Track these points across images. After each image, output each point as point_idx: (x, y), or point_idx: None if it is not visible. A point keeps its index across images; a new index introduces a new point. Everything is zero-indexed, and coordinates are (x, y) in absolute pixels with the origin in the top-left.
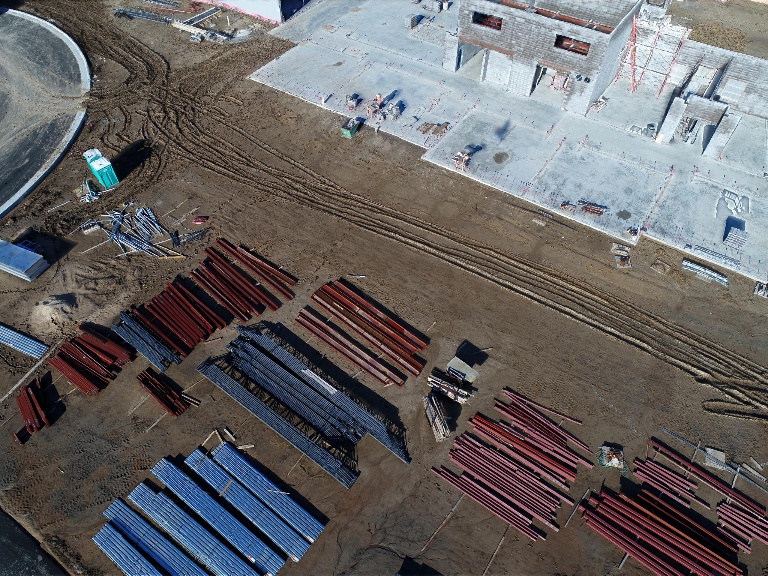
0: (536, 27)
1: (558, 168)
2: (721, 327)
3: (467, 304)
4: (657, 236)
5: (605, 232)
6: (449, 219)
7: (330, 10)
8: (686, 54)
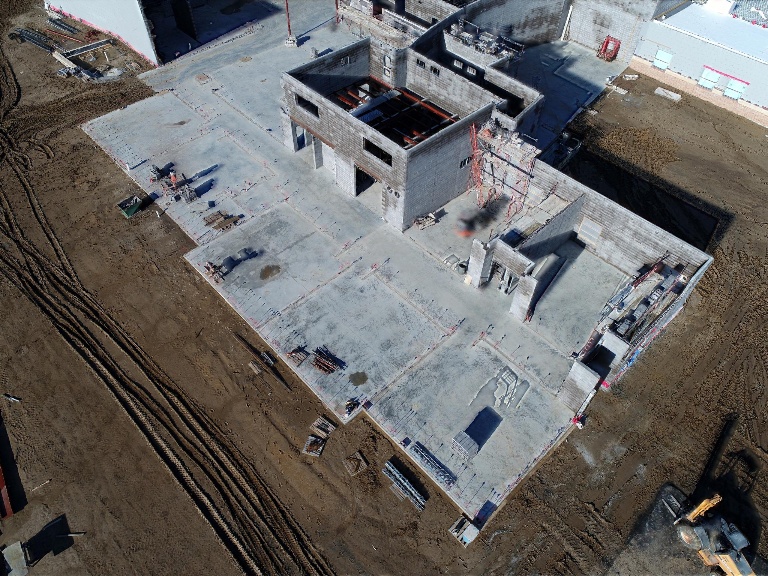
0: (345, 124)
1: (324, 298)
2: (374, 572)
3: (100, 464)
4: (378, 418)
5: (320, 398)
6: (160, 342)
7: (219, 57)
8: (540, 177)
